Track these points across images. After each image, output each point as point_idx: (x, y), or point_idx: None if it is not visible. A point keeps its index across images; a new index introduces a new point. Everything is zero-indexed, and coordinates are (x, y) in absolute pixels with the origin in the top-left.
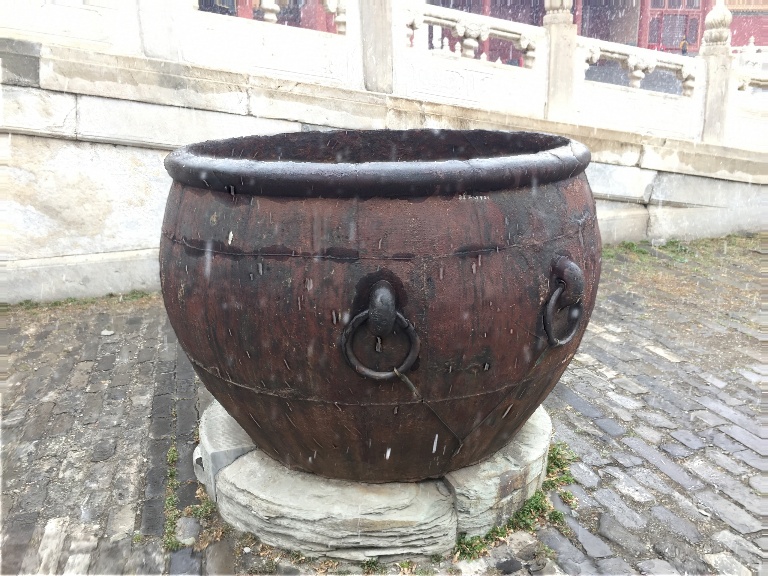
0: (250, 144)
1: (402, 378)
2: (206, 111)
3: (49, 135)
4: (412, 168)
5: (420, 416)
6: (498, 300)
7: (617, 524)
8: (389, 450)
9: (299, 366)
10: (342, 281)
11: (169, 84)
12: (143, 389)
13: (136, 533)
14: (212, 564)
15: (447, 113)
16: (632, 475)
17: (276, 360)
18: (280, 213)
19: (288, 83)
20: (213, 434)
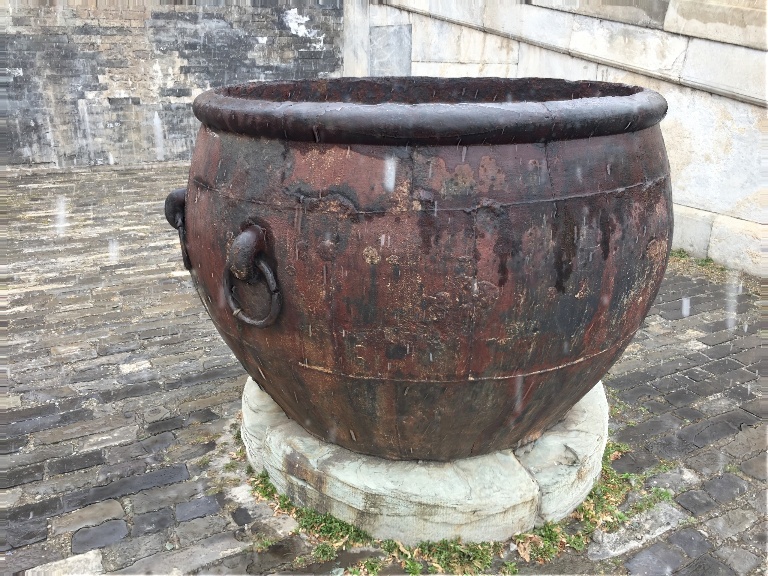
0: (486, 86)
1: None
2: None
3: (660, 77)
4: None
5: None
6: (202, 237)
7: None
8: None
9: None
10: None
11: None
12: None
13: None
14: None
15: None
16: None
17: None
18: None
19: None
20: None
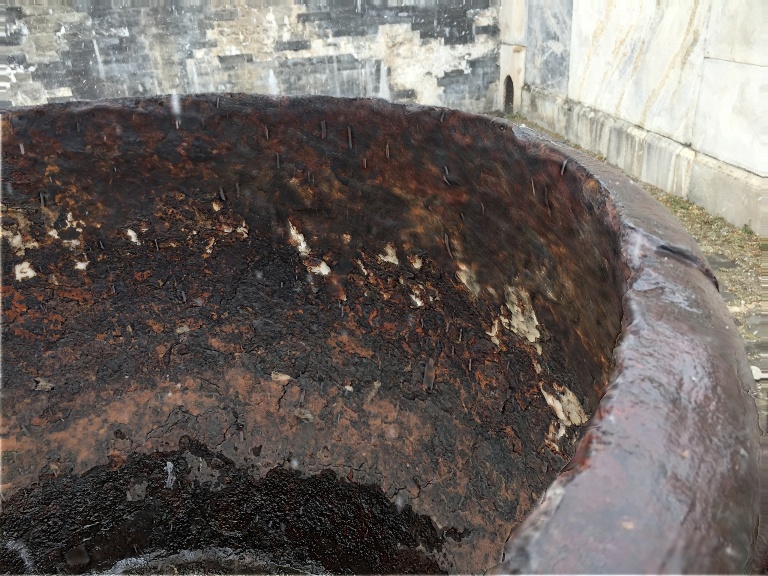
0: (363, 119)
1: None
2: None
3: None
4: None
5: None
6: None
7: None
8: None
9: None
10: None
11: None
12: None
13: None
14: None
15: None
16: None
17: None
18: None
19: None
20: None
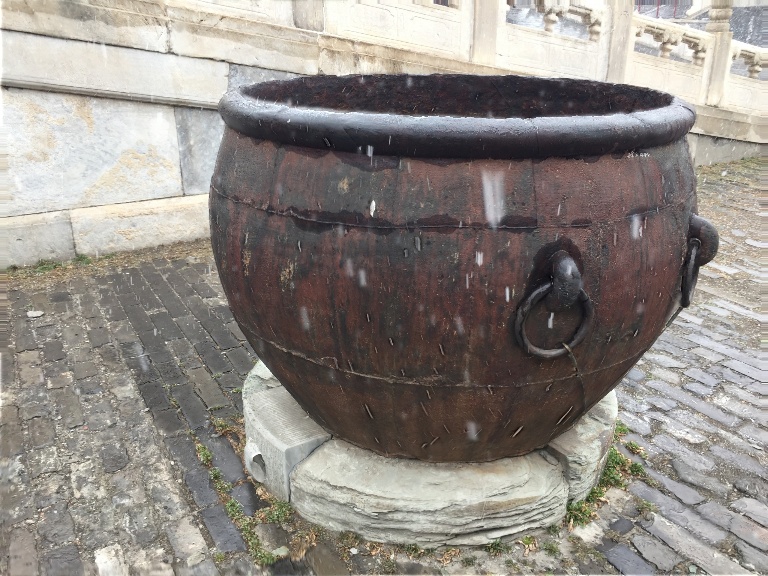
0: (272, 90)
1: (569, 354)
2: (119, 47)
3: None
4: (590, 124)
5: (568, 390)
6: (656, 264)
7: (690, 468)
8: (520, 428)
9: (456, 350)
10: (519, 253)
11: (73, 13)
12: (119, 378)
13: (213, 551)
14: (323, 573)
15: (379, 54)
16: (675, 418)
17: (428, 346)
18: (440, 177)
19: (212, 16)
20: (274, 427)
